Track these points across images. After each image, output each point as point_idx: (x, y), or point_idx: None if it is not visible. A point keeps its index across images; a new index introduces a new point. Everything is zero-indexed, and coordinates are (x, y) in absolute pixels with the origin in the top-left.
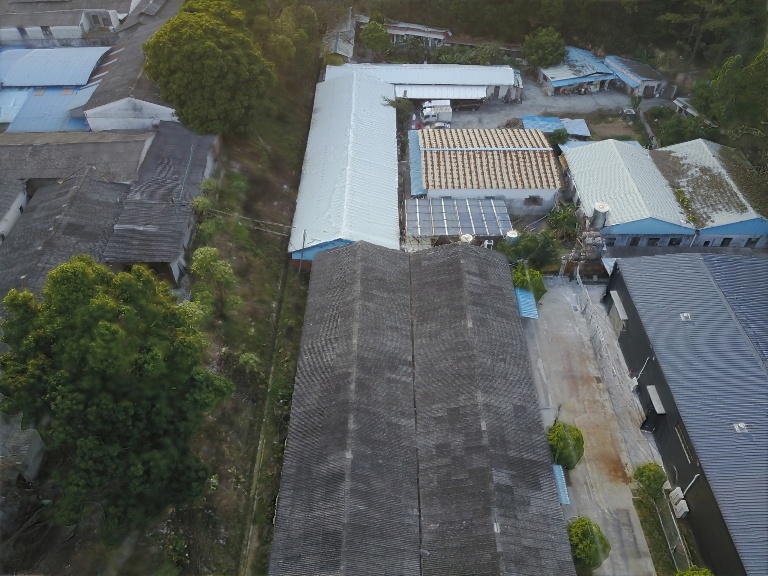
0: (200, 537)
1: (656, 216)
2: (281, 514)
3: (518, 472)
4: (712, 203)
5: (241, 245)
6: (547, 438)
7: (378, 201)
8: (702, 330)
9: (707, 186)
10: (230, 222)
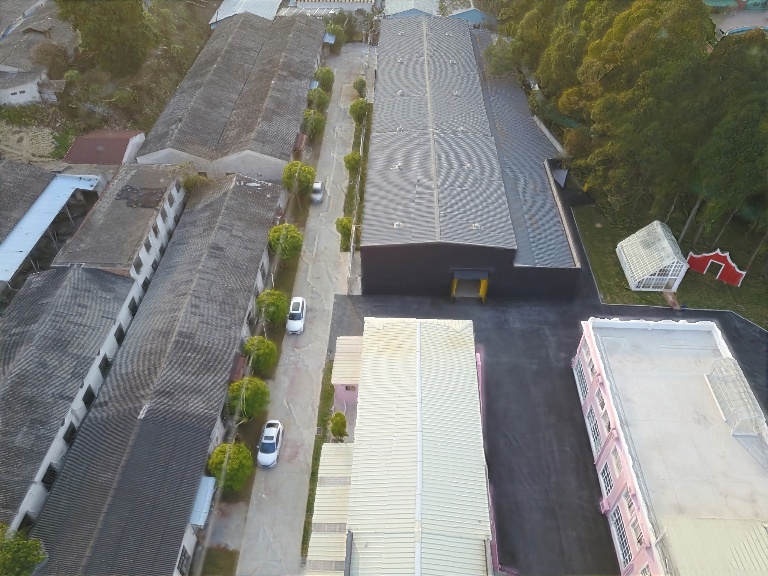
0: (144, 96)
1: (417, 8)
2: (181, 85)
3: (292, 74)
4: (456, 7)
5: (181, 17)
6: (314, 71)
7: (265, 5)
8: (406, 37)
9: (458, 0)
10: (177, 8)
